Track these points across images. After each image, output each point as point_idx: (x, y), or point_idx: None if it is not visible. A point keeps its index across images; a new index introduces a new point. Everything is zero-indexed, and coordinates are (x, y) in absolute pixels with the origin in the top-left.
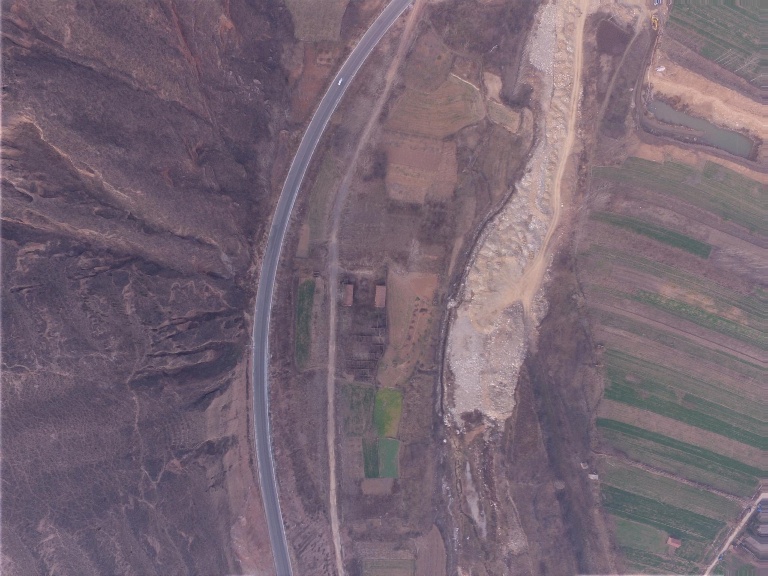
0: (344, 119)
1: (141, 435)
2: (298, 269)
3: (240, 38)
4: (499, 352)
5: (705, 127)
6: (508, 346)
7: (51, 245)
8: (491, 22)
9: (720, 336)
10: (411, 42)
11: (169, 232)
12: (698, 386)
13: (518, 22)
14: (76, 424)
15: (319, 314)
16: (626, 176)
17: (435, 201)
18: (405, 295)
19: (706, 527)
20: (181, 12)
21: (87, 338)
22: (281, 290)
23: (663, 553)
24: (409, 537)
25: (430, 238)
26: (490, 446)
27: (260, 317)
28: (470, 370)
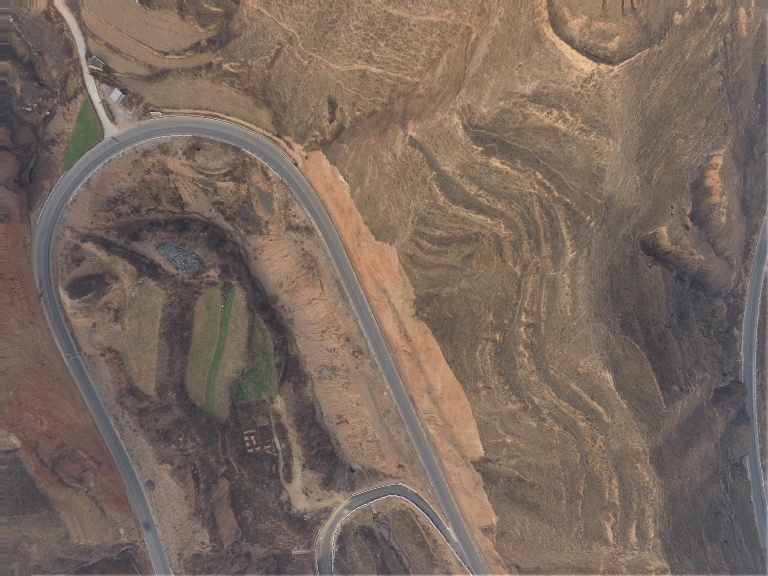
0: None
1: (721, 450)
2: None
3: None
4: None
5: None
6: None
7: None
8: None
9: None
10: None
11: None
12: None
13: None
14: (704, 442)
15: None
16: None
17: None
18: None
19: None
20: None
21: (701, 359)
22: (762, 306)
23: None
24: None
25: None
26: None
27: (747, 333)
28: None
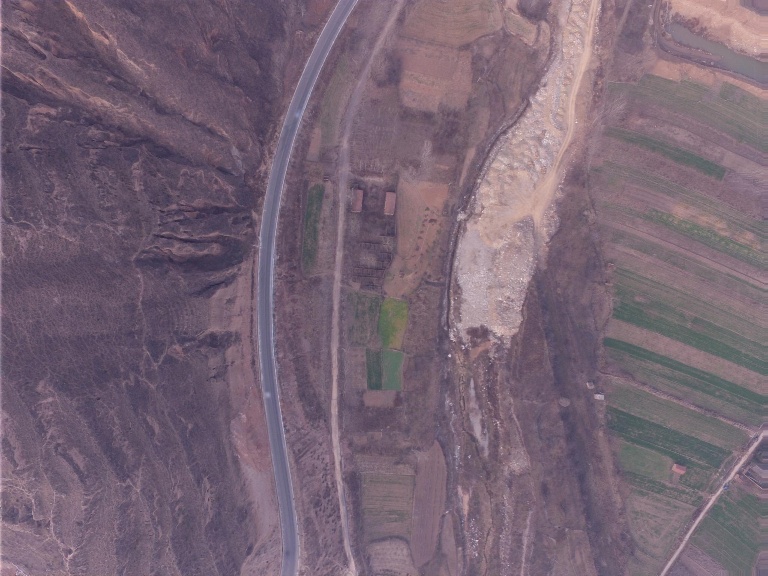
0: (360, 23)
1: (144, 314)
2: (308, 170)
3: None
4: (508, 266)
5: (723, 52)
6: (517, 260)
7: (62, 111)
8: None
9: (732, 260)
10: None
11: (181, 115)
12: (708, 310)
13: None
14: (80, 291)
15: (327, 219)
16: (642, 93)
17: (448, 110)
18: (415, 204)
19: (712, 455)
20: None
21: (94, 207)
22: (290, 192)
23: (667, 480)
24: (410, 452)
25: (442, 147)
26: (495, 363)
27: (268, 217)
28: (478, 284)
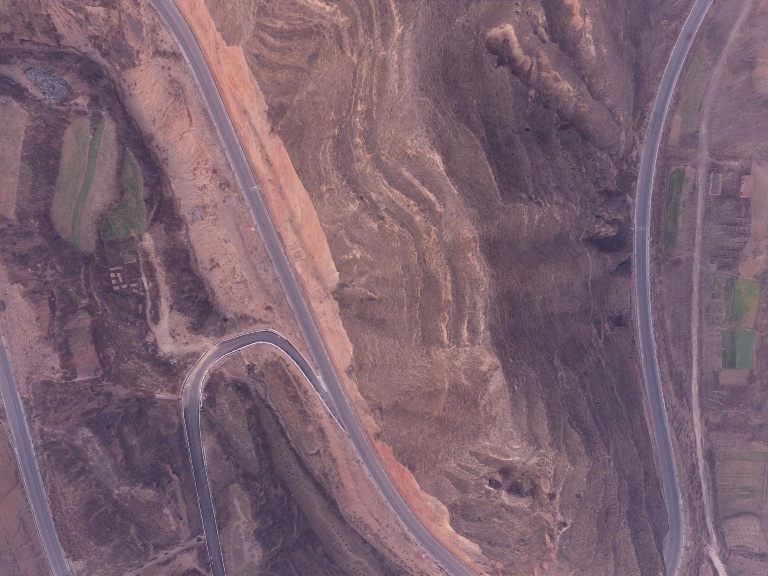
0: (716, 13)
1: (592, 293)
2: None
3: None
4: None
5: None
6: None
7: (535, 95)
8: None
9: None
10: None
11: (602, 100)
12: None
13: None
14: (564, 269)
15: (687, 203)
16: None
17: None
18: (766, 187)
19: None
20: None
21: (565, 188)
22: (657, 176)
23: None
24: (763, 429)
25: None
26: None
27: (641, 201)
28: None
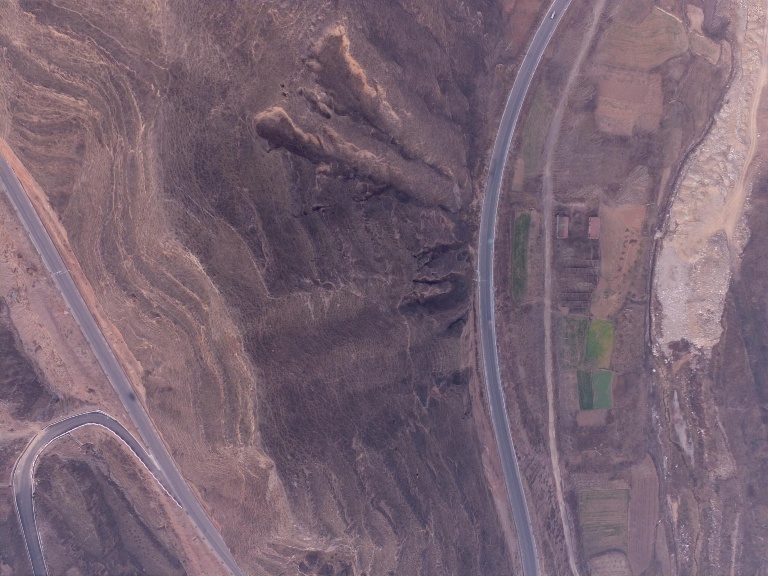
0: (555, 53)
1: (412, 360)
2: None
3: None
4: (707, 280)
5: None
6: (716, 273)
7: (333, 167)
8: None
9: None
10: None
11: (421, 159)
12: None
13: None
14: (369, 345)
15: (534, 248)
16: None
17: (643, 133)
18: (615, 227)
19: None
20: None
21: (370, 260)
22: (501, 224)
23: None
24: (623, 467)
25: None
26: (697, 374)
27: (484, 250)
28: (676, 299)
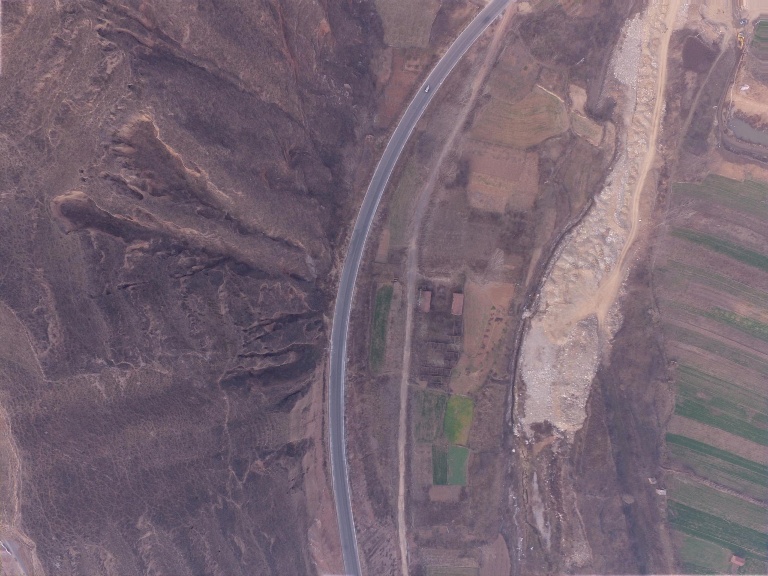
0: (429, 126)
1: (230, 435)
2: (379, 274)
3: (334, 42)
4: (572, 364)
5: None
6: (582, 358)
7: (154, 243)
8: (579, 35)
9: None
10: (499, 52)
11: (262, 233)
12: None
13: (605, 36)
14: (173, 422)
15: (395, 319)
16: (706, 193)
17: (515, 211)
18: (481, 304)
19: None
20: (286, 15)
21: (185, 337)
22: (360, 294)
23: (726, 571)
24: (474, 545)
25: (509, 248)
26: (558, 457)
27: (339, 320)
28: (542, 381)
